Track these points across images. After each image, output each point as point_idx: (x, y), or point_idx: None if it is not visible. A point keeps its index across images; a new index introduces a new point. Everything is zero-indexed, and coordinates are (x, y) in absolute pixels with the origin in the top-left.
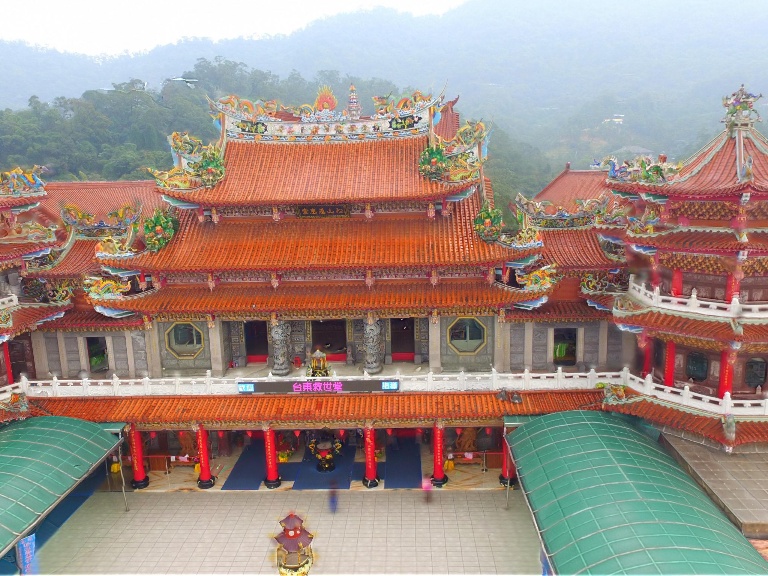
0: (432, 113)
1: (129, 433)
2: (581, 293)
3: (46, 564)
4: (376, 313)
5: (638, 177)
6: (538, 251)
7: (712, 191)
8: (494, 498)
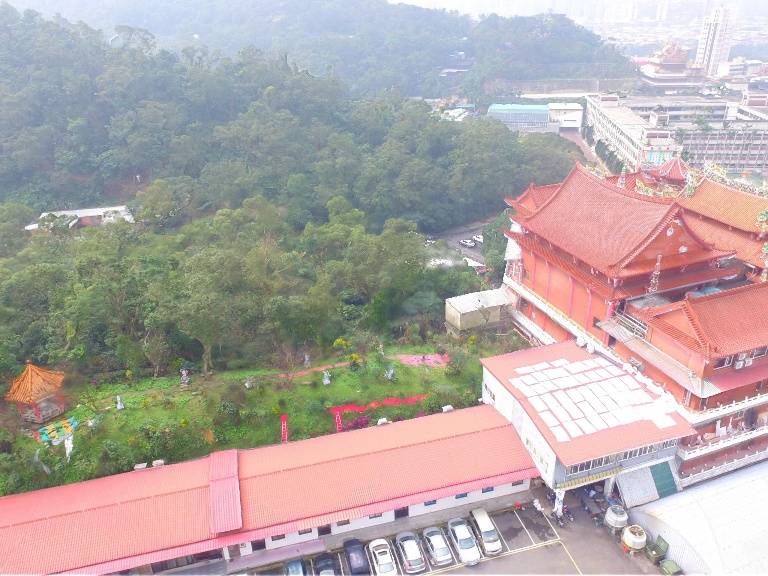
0: None
1: None
2: None
3: None
4: None
5: None
6: None
7: None
8: None
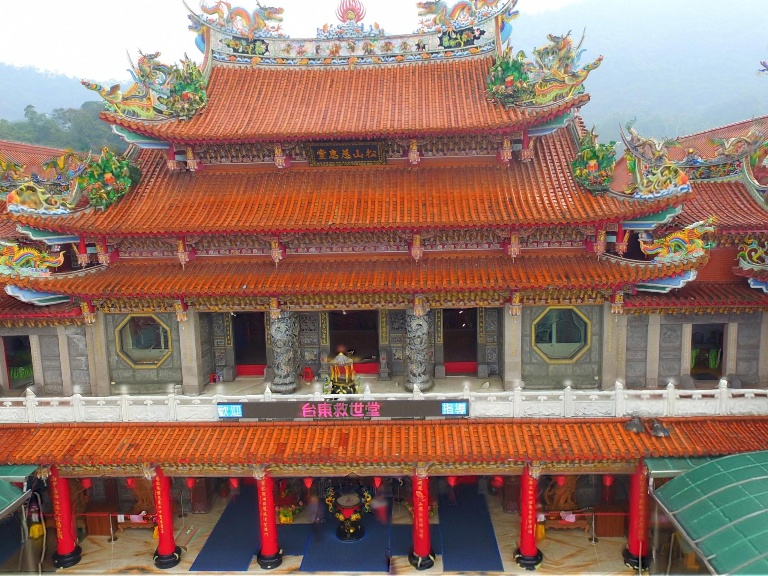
0: (499, 24)
1: (48, 481)
2: (739, 269)
3: None
4: (426, 300)
5: None
6: (682, 200)
7: None
8: None
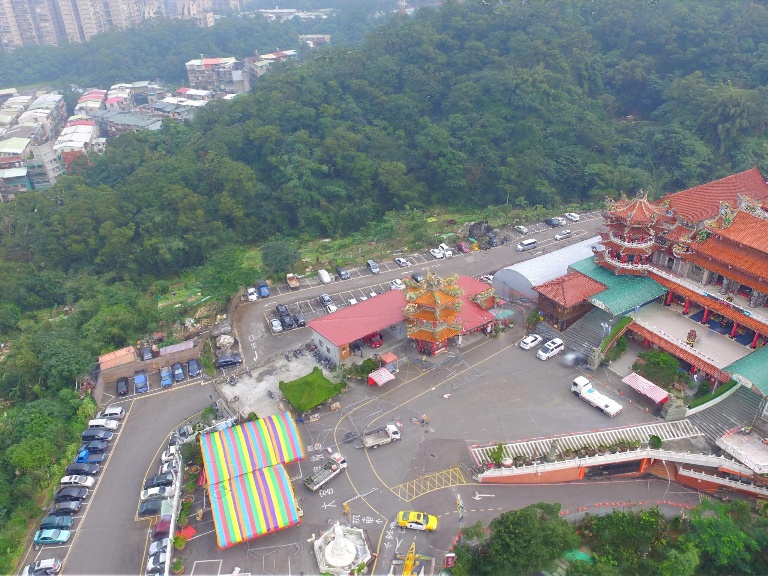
0: None
1: (670, 291)
2: None
3: (639, 313)
4: None
5: None
6: None
7: None
8: None
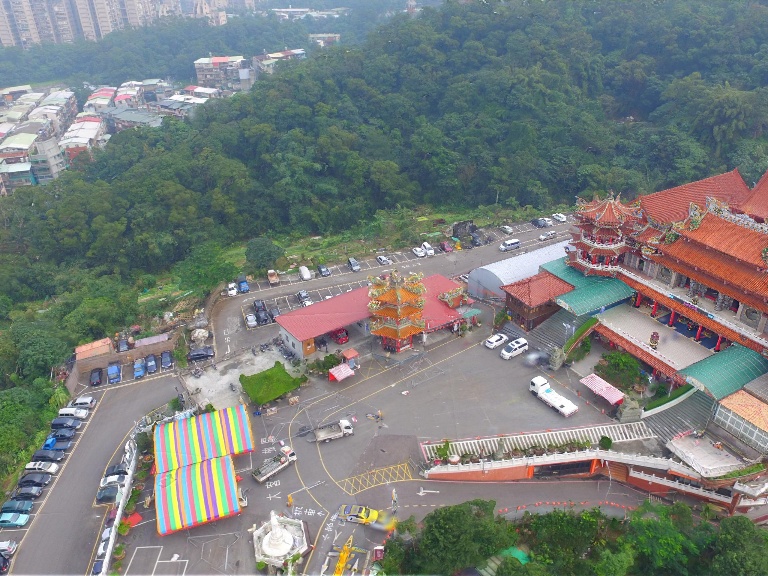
0: None
1: (638, 293)
2: None
3: (606, 314)
4: None
5: None
6: None
7: None
8: None
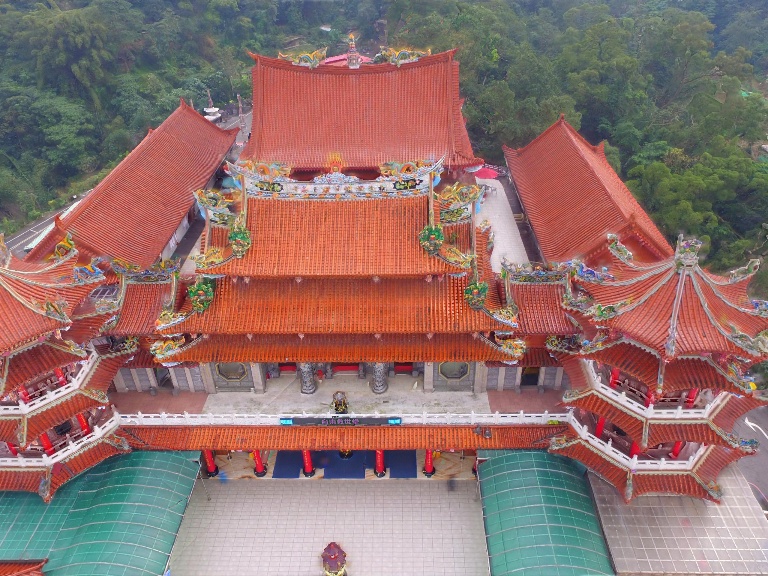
0: (432, 177)
1: None
2: (546, 348)
3: None
4: None
5: (594, 315)
6: (513, 330)
7: (647, 341)
8: (468, 488)
